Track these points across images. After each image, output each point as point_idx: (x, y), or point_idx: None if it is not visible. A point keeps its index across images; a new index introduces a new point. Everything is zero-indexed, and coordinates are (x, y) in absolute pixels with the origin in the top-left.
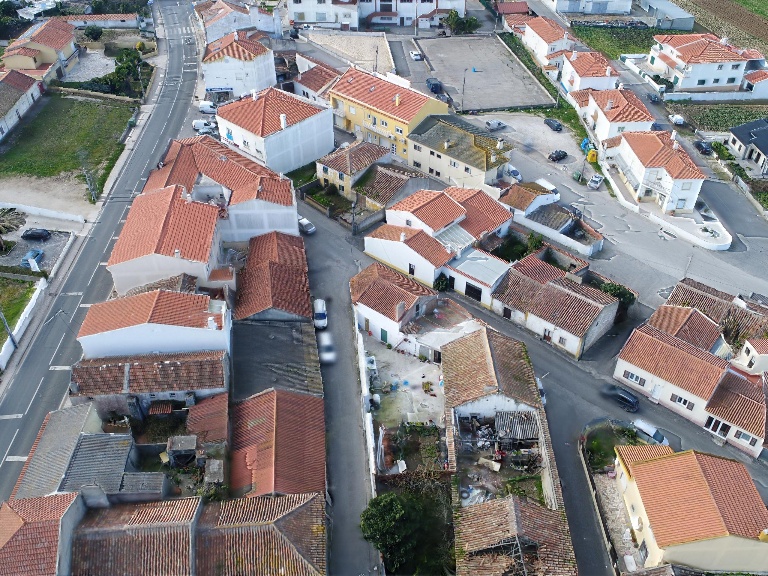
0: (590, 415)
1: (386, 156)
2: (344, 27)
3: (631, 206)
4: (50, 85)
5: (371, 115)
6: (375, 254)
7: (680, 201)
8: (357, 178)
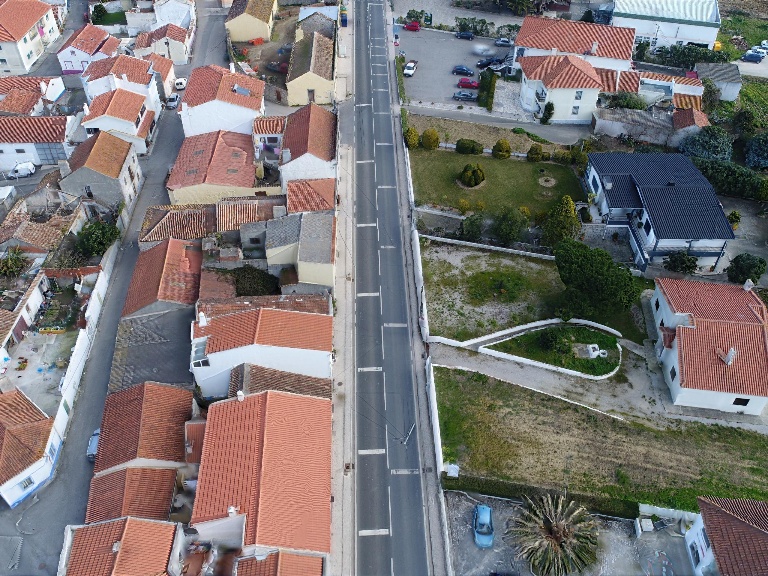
0: None
1: None
2: None
3: None
4: None
5: None
6: None
7: None
8: None
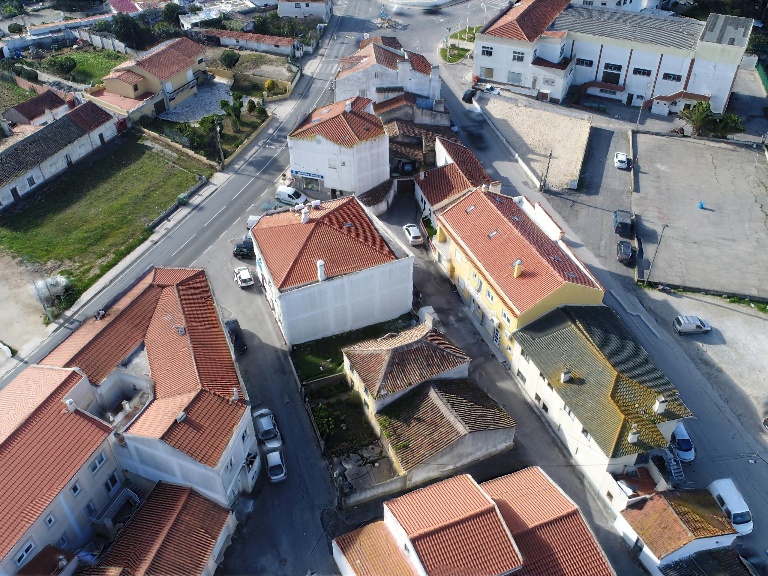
0: None
1: (456, 368)
2: (542, 96)
3: None
4: (136, 122)
5: (477, 276)
6: (343, 573)
7: None
8: (390, 400)
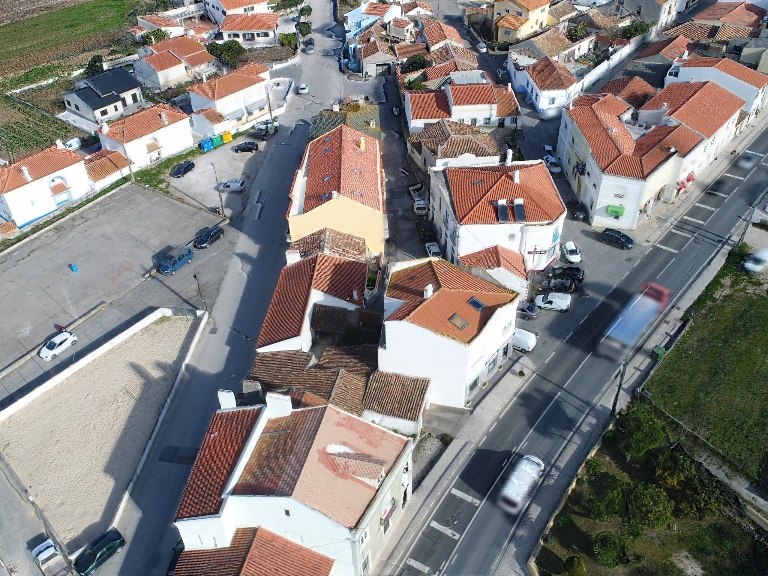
0: (495, 57)
1: None
2: None
3: None
4: None
5: None
6: None
7: None
8: None
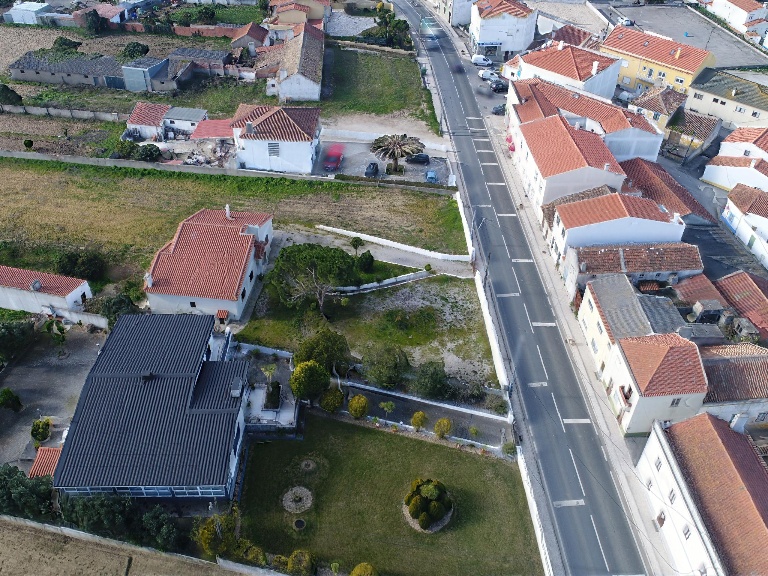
0: None
1: (685, 101)
2: None
3: None
4: (326, 38)
5: (648, 67)
6: (714, 180)
7: None
8: (669, 118)
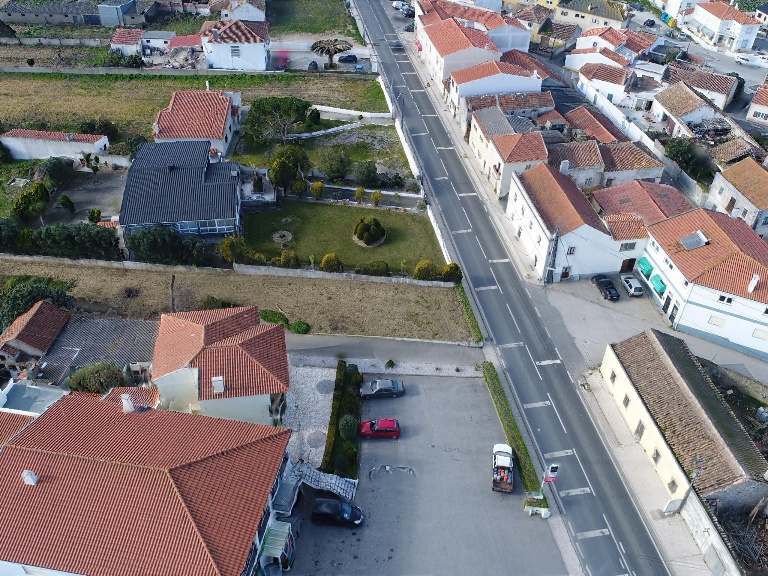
0: None
1: (552, 15)
2: None
3: (712, 48)
4: None
5: None
6: (573, 67)
7: (744, 42)
8: (540, 27)
